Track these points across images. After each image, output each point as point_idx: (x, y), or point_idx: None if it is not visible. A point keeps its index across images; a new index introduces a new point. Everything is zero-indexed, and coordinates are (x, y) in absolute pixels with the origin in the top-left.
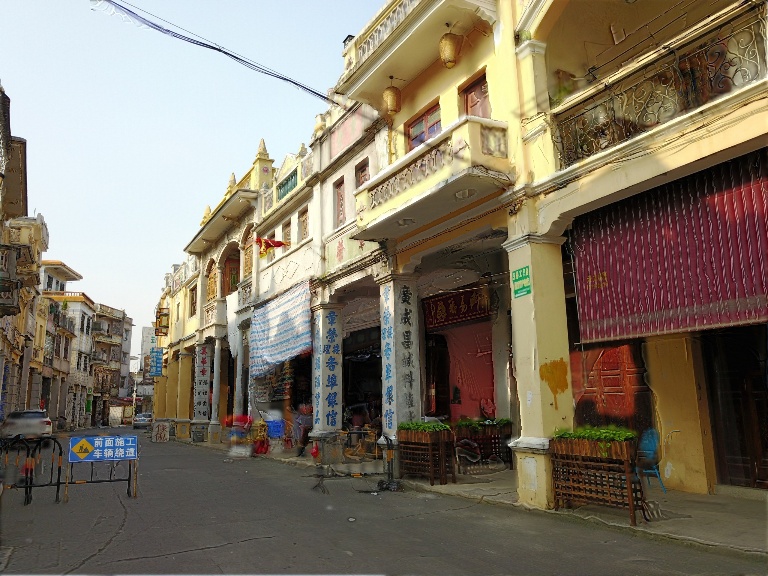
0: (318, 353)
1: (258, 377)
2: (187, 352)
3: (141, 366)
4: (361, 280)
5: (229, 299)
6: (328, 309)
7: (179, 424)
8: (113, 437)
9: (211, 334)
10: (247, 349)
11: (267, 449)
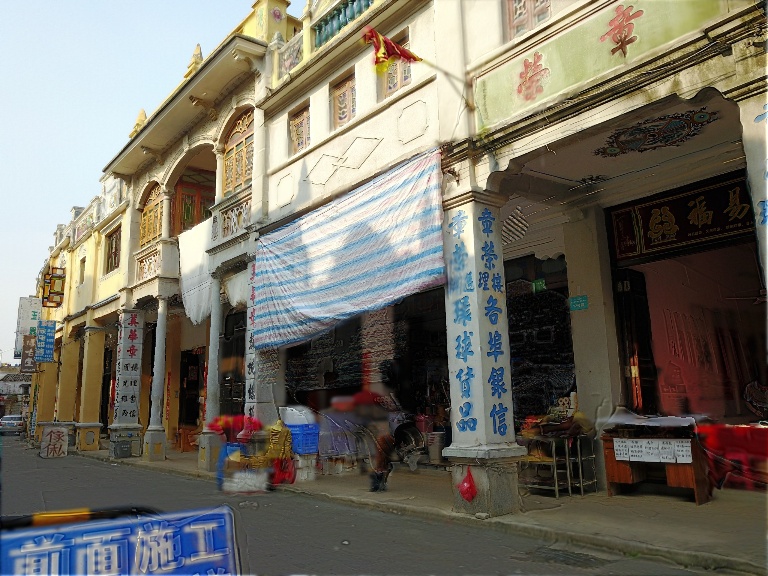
0: (461, 289)
1: (287, 346)
2: (98, 325)
3: (16, 350)
4: (613, 122)
5: (185, 238)
6: (481, 204)
7: (83, 430)
8: (124, 522)
9: (151, 292)
10: (227, 309)
11: (295, 475)
